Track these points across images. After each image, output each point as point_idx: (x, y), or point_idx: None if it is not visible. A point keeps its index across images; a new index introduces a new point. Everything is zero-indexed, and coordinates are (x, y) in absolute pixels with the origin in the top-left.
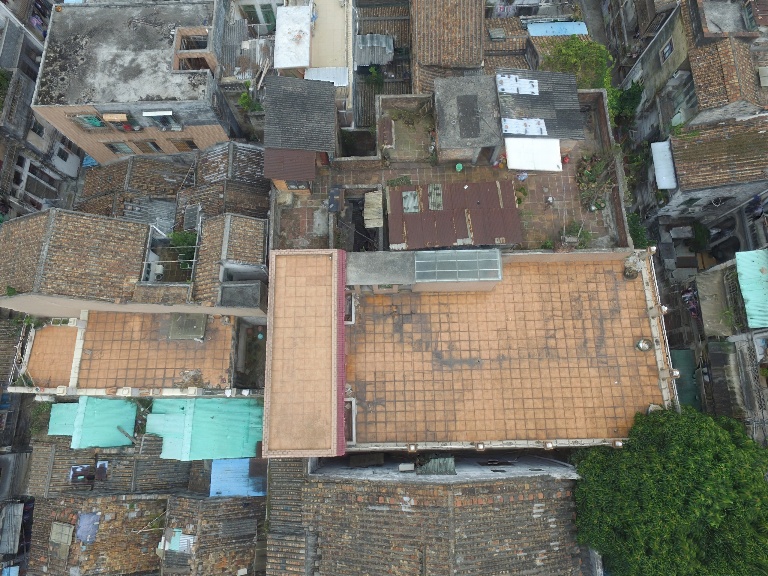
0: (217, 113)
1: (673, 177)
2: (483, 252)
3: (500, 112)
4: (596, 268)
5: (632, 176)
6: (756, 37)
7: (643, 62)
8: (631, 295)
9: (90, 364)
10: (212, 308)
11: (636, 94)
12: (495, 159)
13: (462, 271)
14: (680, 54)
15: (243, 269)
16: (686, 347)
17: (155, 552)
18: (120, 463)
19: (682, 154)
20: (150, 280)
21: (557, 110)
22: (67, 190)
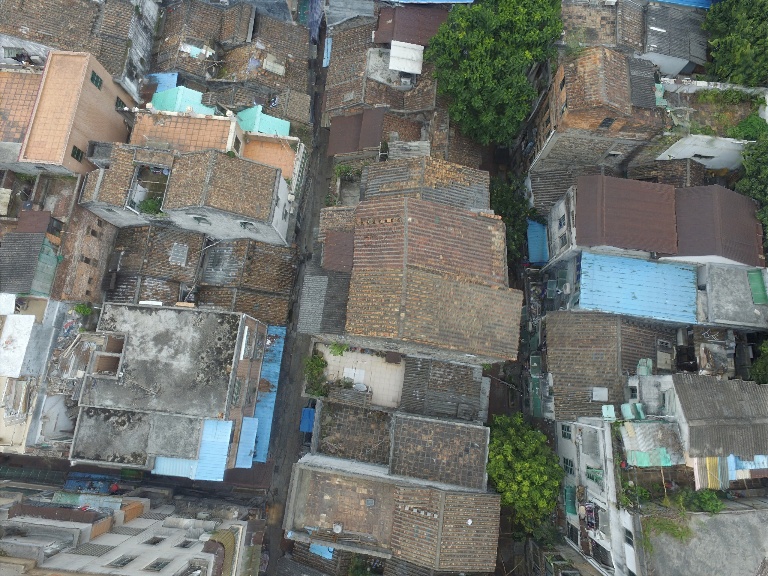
0: None
1: None
2: None
3: None
4: None
5: None
6: None
7: None
8: None
9: (223, 134)
10: None
11: None
12: None
13: None
14: None
15: None
16: None
17: None
18: None
19: None
20: None
21: None
22: None
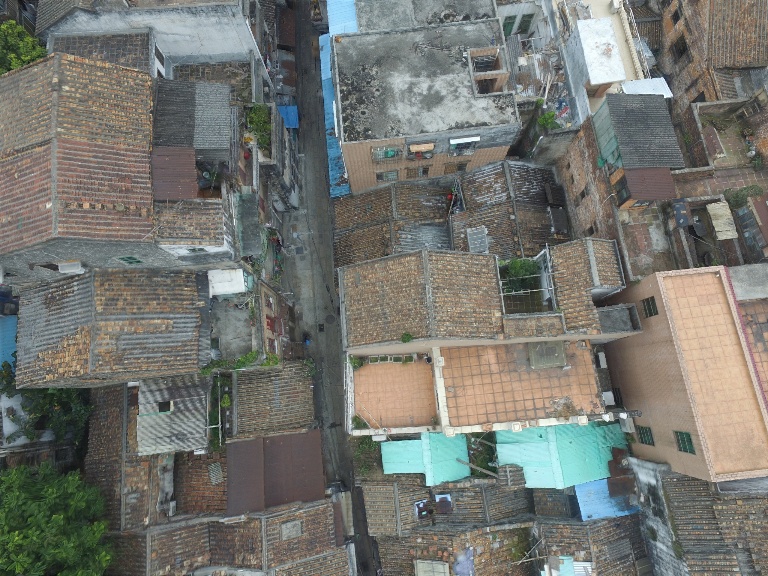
0: (518, 134)
1: None
2: None
3: None
4: None
5: None
6: None
7: None
8: None
9: (456, 401)
10: (591, 335)
11: None
12: None
13: None
14: None
15: (596, 292)
16: None
17: None
18: (463, 495)
19: None
20: None
21: None
22: (290, 221)
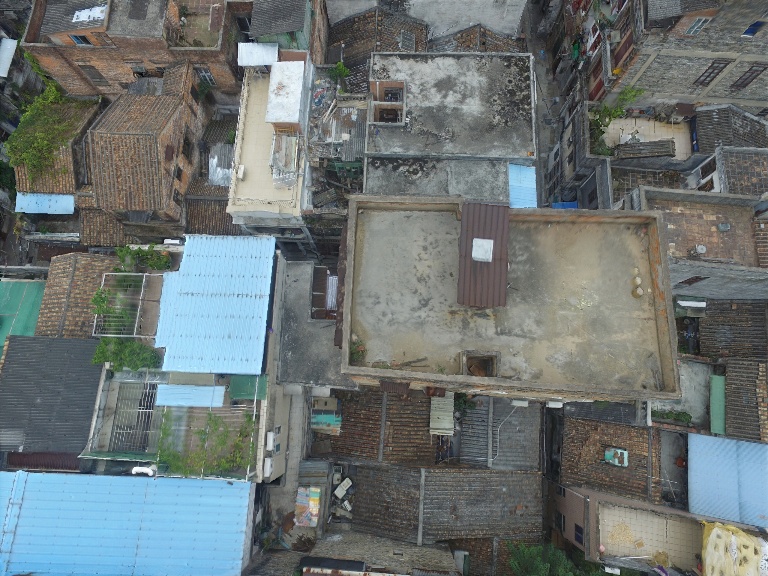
0: None
1: (2, 46)
2: None
3: None
4: None
5: None
6: None
7: None
8: None
9: None
10: None
11: None
12: None
13: None
14: None
15: None
16: None
17: None
18: None
19: None
20: None
21: (66, 3)
22: None
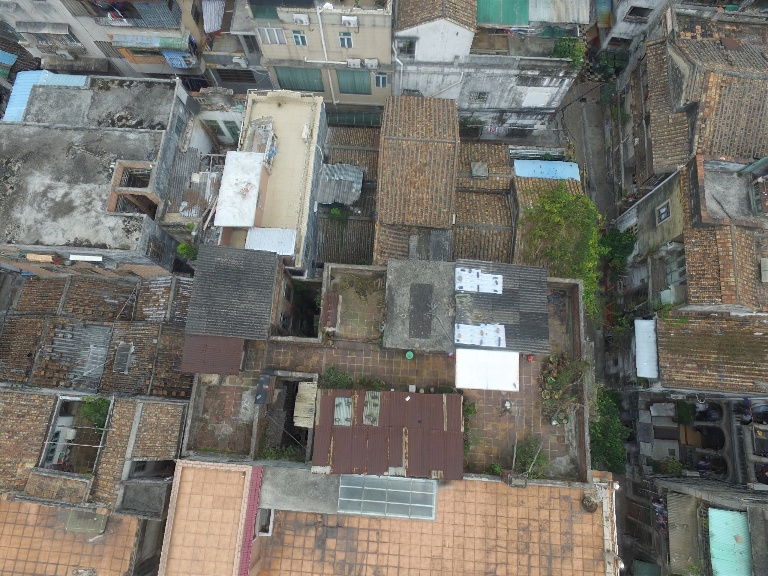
0: (153, 259)
1: (655, 365)
2: (418, 482)
3: (455, 313)
4: (551, 491)
5: (603, 385)
6: (760, 228)
7: (639, 210)
8: (587, 529)
9: None
10: None
11: (628, 245)
12: None
13: (391, 504)
14: (676, 225)
15: None
16: (653, 557)
17: None
18: None
19: (667, 342)
20: (57, 450)
21: (521, 313)
22: (12, 284)
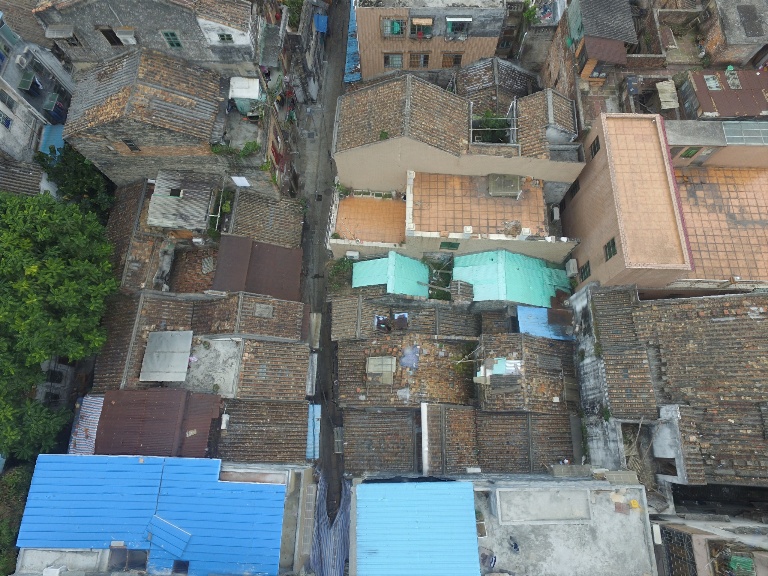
0: (505, 23)
1: None
2: None
3: None
4: None
5: None
6: None
7: None
8: None
9: (421, 213)
10: (542, 163)
11: None
12: (764, 62)
13: (766, 137)
14: None
15: (553, 140)
16: None
17: (473, 381)
18: (419, 314)
19: None
20: None
21: None
22: None
